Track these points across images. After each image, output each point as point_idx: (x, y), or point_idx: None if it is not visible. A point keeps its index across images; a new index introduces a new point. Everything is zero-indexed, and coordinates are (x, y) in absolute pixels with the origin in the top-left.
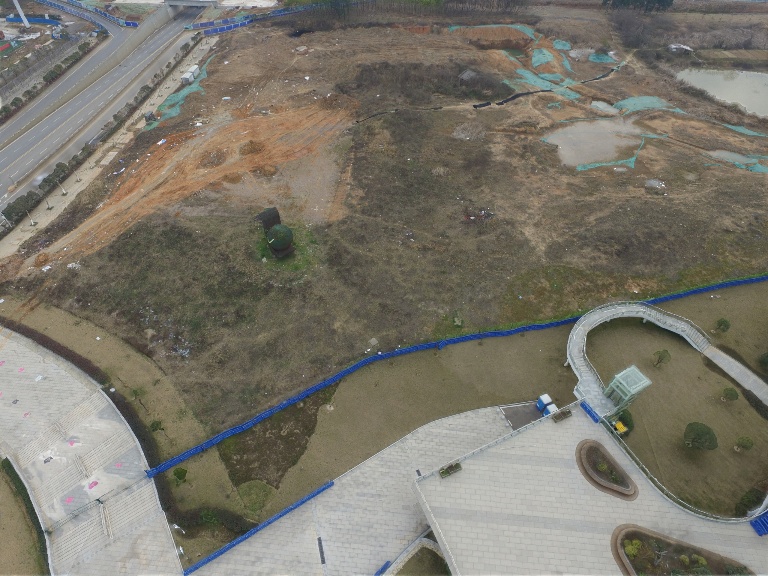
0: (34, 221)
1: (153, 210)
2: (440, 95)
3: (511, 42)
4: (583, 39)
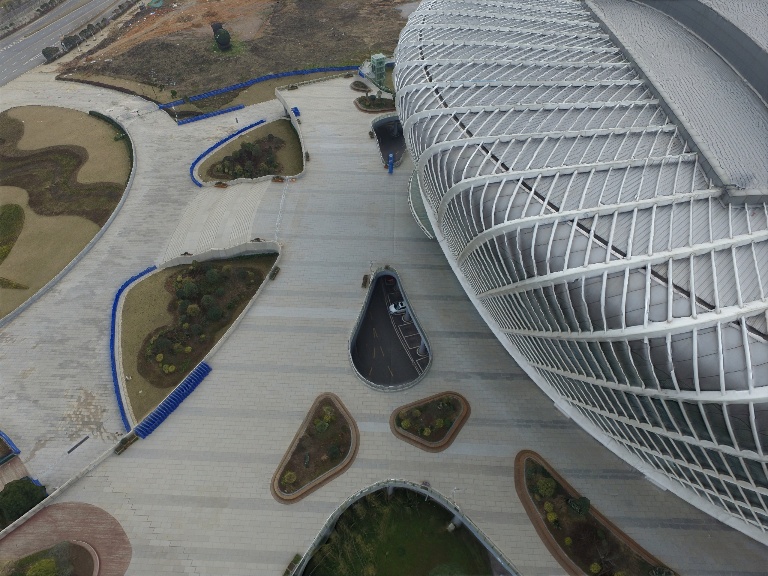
0: (80, 50)
1: (151, 38)
2: None
3: None
4: None
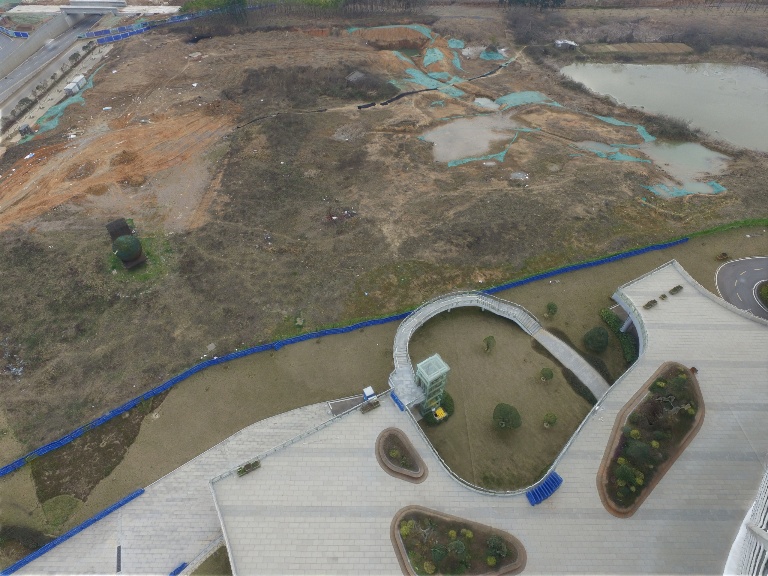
0: None
1: (7, 227)
2: (327, 97)
3: (409, 42)
4: (477, 37)
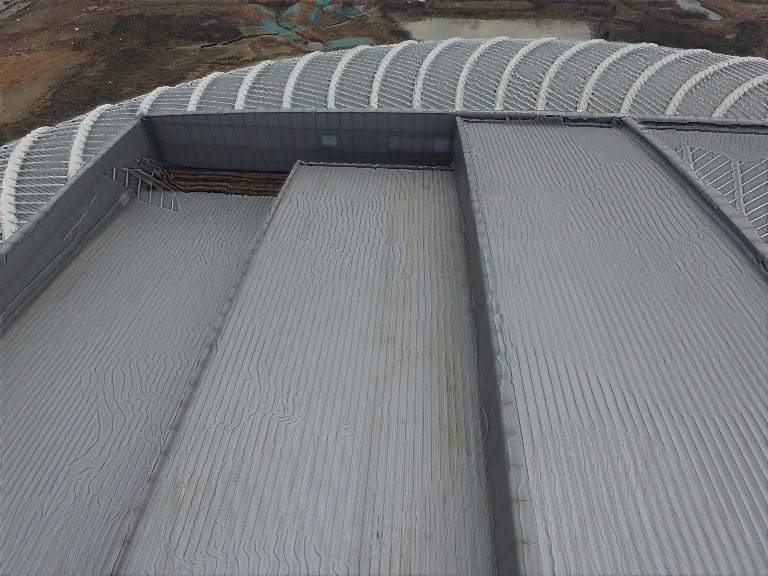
0: None
1: None
2: (181, 39)
3: (285, 0)
4: None
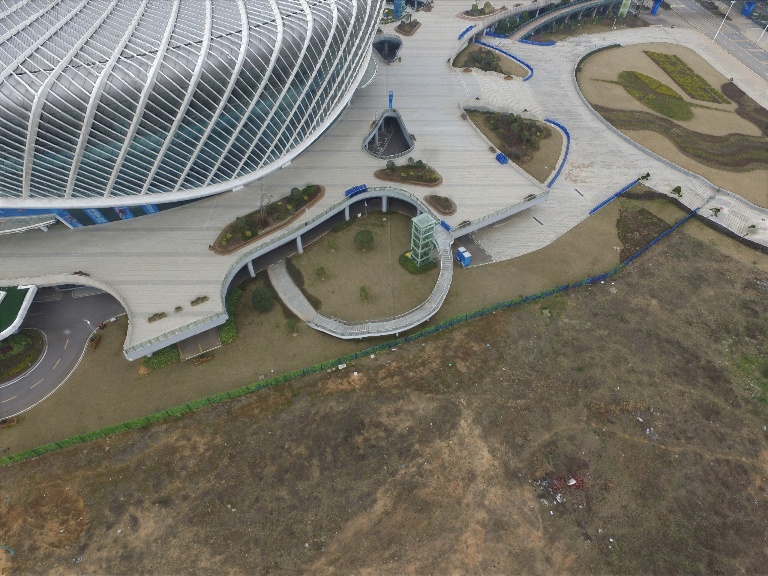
0: None
1: None
2: None
3: None
4: None
